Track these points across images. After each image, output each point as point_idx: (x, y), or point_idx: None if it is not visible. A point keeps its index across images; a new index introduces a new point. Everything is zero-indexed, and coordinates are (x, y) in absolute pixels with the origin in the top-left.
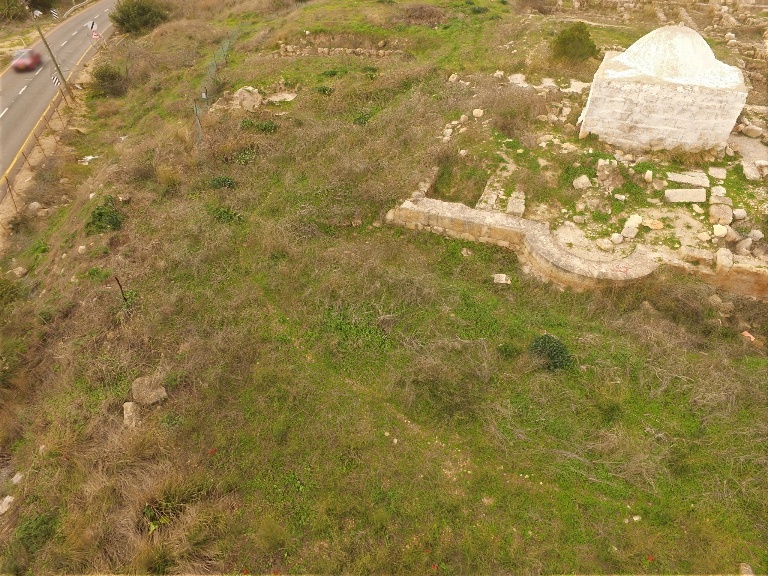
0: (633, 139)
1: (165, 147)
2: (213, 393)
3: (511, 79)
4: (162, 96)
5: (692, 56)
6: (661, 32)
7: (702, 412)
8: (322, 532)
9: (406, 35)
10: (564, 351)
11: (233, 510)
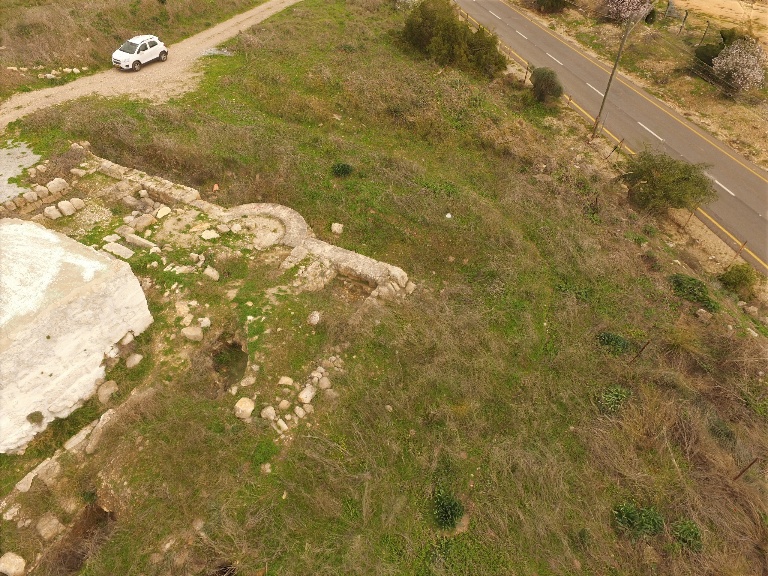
0: None
1: None
2: None
3: None
4: None
5: None
6: None
7: None
8: None
9: None
10: None
11: None
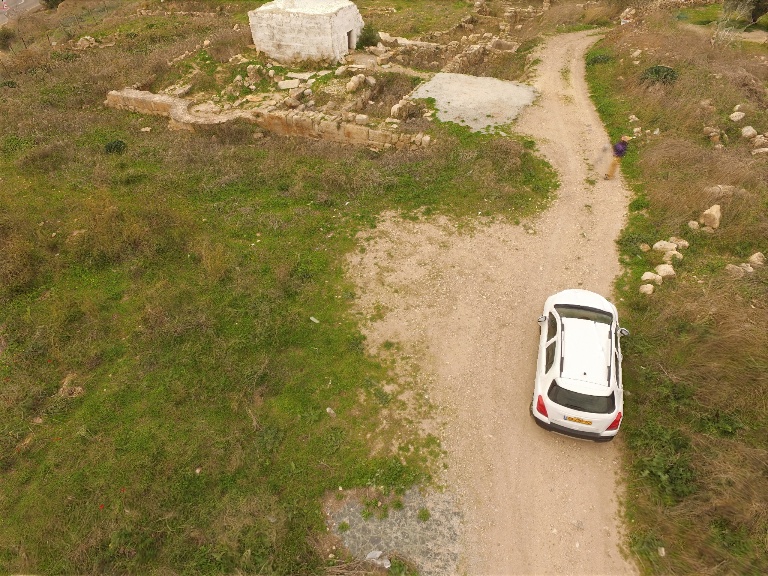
0: (284, 54)
1: None
2: None
3: None
4: None
5: None
6: None
7: None
8: None
9: (238, 2)
10: (118, 145)
11: None
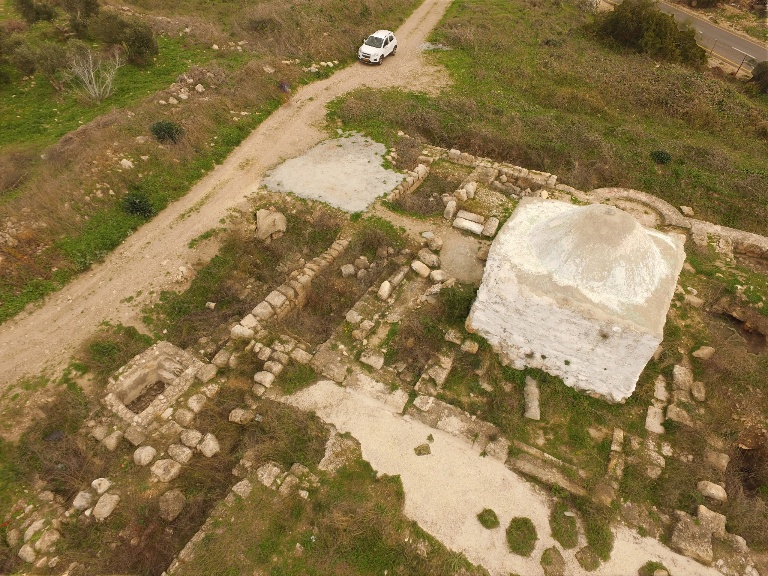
0: None
1: None
2: None
3: None
4: None
5: None
6: None
7: None
8: None
9: None
10: (657, 152)
11: (766, 141)
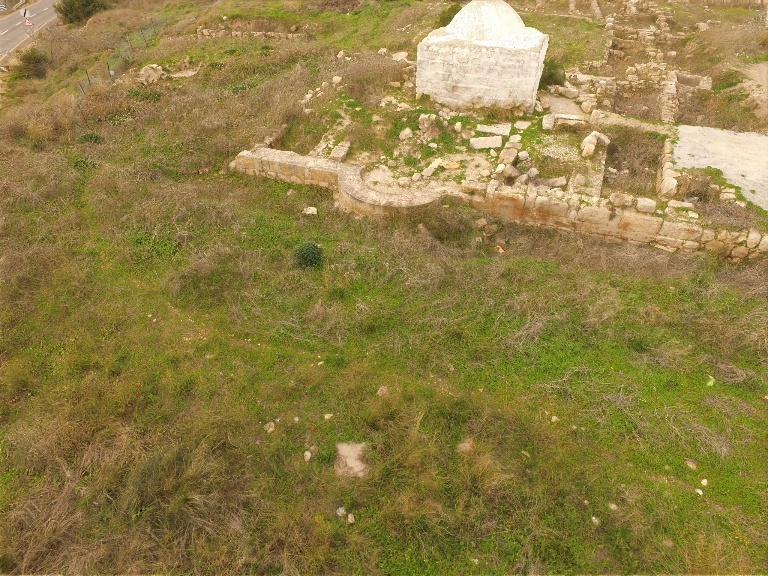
0: (458, 98)
1: (49, 111)
2: (8, 287)
3: (394, 56)
4: (77, 75)
5: (497, 22)
6: (473, 2)
7: (409, 293)
8: (64, 378)
9: (317, 20)
10: (316, 253)
11: None
